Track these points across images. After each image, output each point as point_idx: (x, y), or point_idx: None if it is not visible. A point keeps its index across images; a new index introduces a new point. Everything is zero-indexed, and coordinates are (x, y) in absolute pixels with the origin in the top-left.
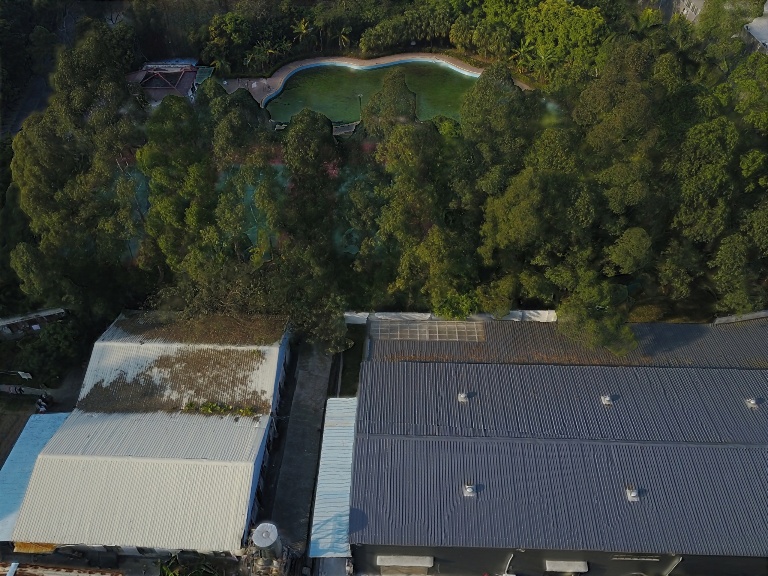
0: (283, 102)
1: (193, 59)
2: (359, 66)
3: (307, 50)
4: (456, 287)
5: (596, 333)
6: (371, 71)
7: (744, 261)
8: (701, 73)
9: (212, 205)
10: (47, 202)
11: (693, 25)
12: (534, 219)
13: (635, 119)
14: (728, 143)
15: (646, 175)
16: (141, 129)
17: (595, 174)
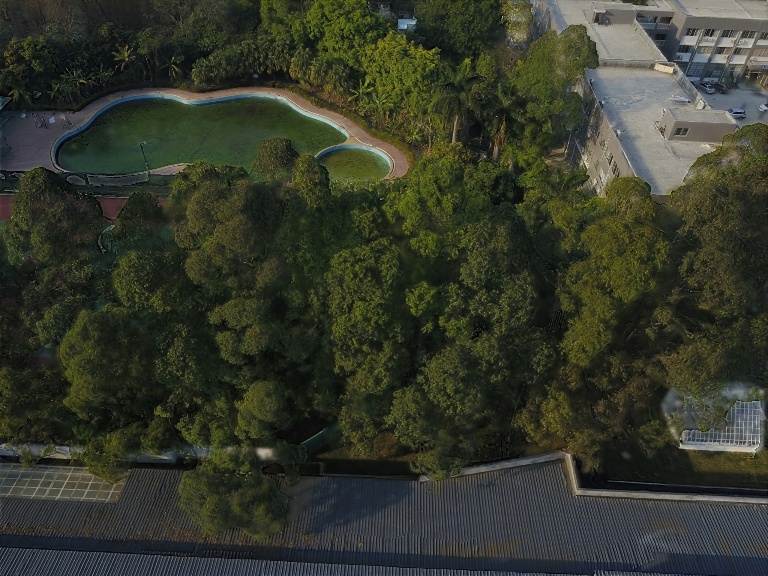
0: (82, 141)
1: None
2: (187, 100)
3: (134, 79)
4: (95, 426)
5: (211, 517)
6: (200, 107)
7: (420, 421)
8: (525, 134)
9: None
10: None
11: (516, 79)
12: (92, 380)
13: (236, 248)
14: (384, 275)
15: (296, 307)
16: None
17: (209, 310)
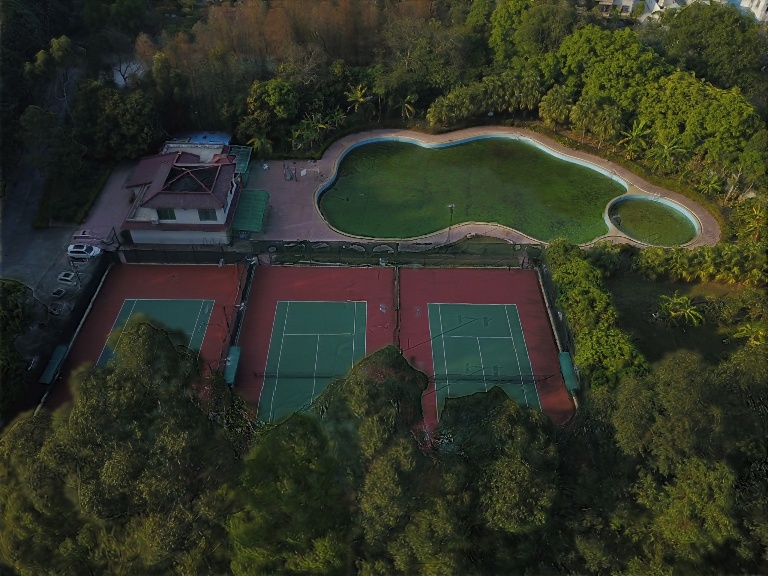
0: (340, 196)
1: (225, 134)
2: (428, 144)
3: (362, 121)
4: None
5: None
6: (443, 150)
7: None
8: None
9: (343, 572)
10: (46, 558)
11: None
12: None
13: None
14: None
15: None
16: (235, 498)
17: None
